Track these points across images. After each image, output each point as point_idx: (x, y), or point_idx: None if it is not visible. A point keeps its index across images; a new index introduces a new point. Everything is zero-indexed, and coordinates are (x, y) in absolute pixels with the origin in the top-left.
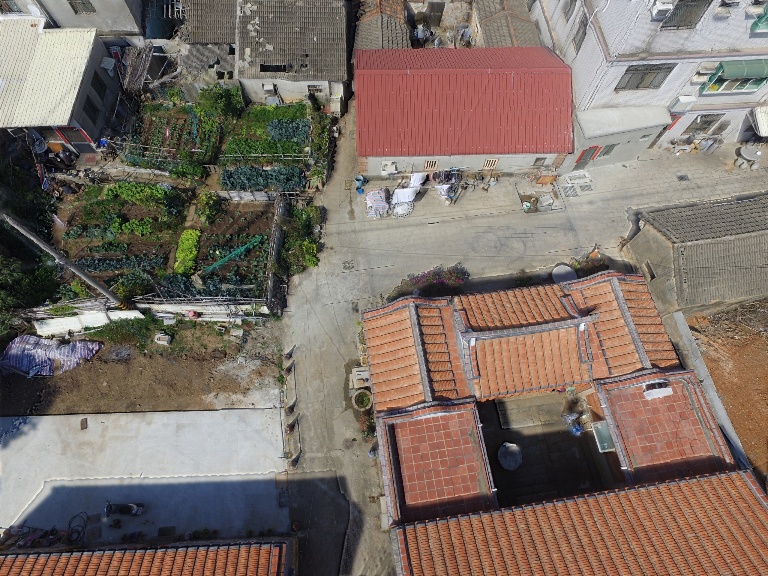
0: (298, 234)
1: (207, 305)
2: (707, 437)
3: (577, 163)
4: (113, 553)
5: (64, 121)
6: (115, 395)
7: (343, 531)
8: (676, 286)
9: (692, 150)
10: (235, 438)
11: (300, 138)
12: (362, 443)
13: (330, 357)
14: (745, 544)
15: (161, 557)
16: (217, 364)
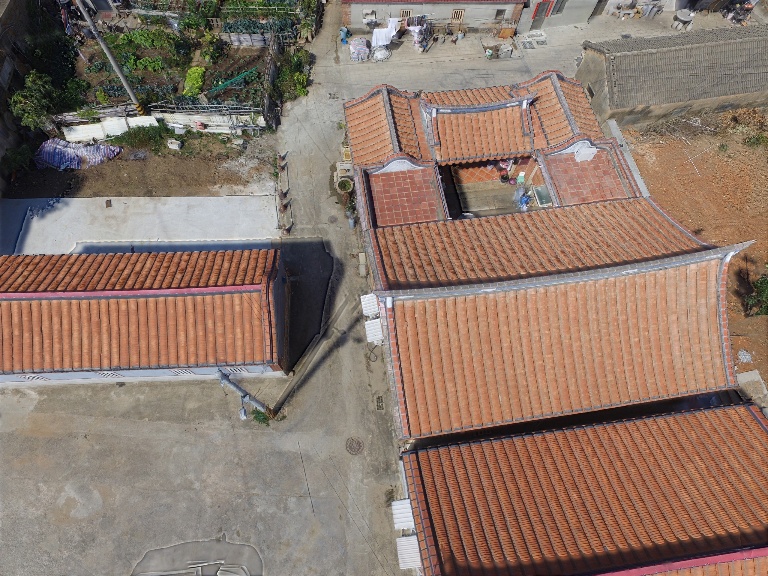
0: (290, 69)
1: (212, 115)
2: (624, 186)
3: (534, 20)
4: (140, 254)
5: None
6: (134, 185)
7: (328, 277)
8: (608, 92)
9: (635, 14)
10: (237, 215)
11: (292, 1)
12: (344, 219)
13: (318, 160)
14: (642, 230)
15: (179, 255)
16: (221, 163)
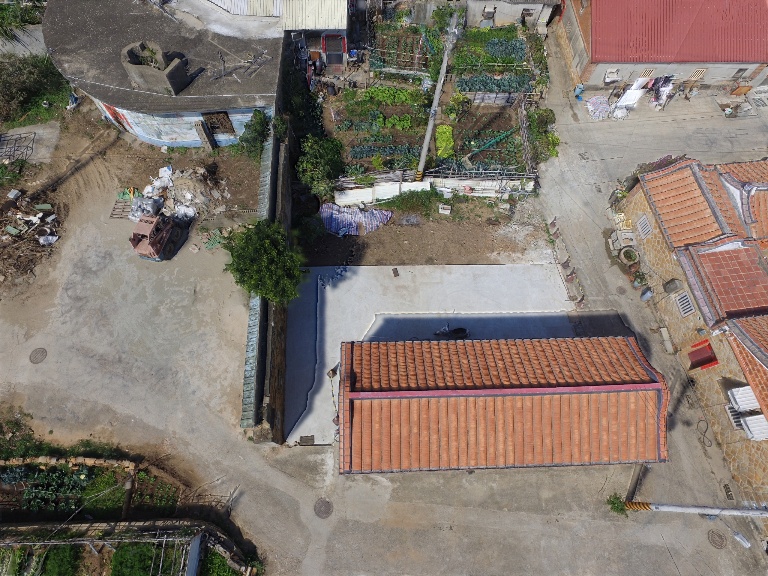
0: None
1: (483, 180)
2: None
3: None
4: (497, 341)
5: (343, 26)
6: (414, 252)
7: None
8: None
9: None
10: (525, 285)
11: None
12: (633, 290)
13: (588, 226)
14: None
15: (539, 343)
16: (495, 229)
